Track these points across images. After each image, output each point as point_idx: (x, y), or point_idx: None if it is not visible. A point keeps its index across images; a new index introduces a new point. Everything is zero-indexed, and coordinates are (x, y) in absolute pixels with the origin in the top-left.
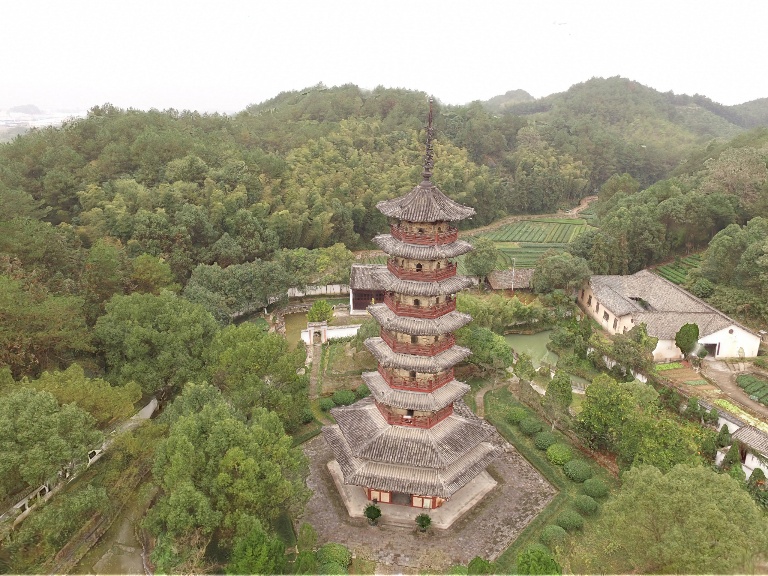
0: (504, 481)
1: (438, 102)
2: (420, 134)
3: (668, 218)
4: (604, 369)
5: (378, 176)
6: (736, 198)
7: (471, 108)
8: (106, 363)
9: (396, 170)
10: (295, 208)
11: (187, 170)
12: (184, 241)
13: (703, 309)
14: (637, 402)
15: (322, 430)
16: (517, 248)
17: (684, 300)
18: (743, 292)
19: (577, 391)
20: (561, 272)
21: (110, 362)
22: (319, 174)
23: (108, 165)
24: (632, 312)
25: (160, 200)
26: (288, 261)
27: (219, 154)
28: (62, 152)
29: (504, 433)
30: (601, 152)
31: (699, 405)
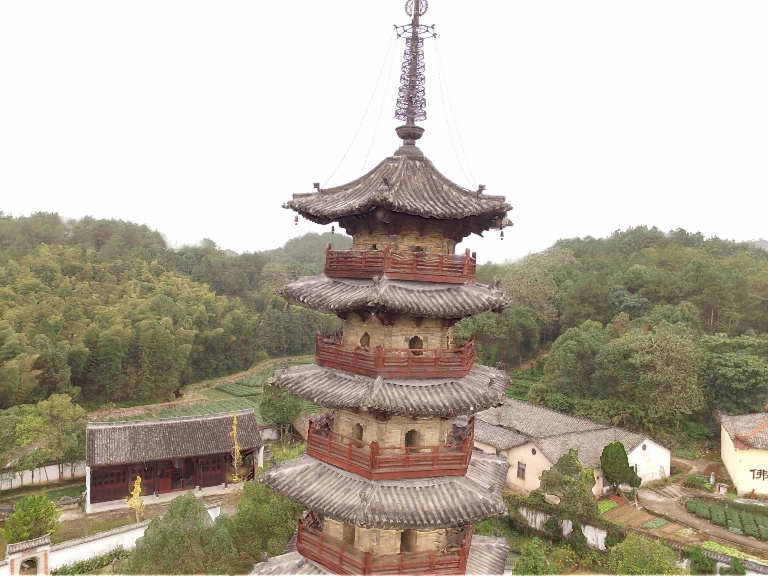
0: None
1: (163, 238)
2: (151, 265)
3: (480, 334)
4: (527, 529)
5: (103, 309)
6: (533, 311)
7: (203, 246)
8: None
9: None
10: None
11: None
12: None
13: (593, 425)
14: (608, 572)
15: None
16: None
17: (560, 419)
18: (611, 402)
19: None
20: None
21: None
22: (9, 305)
23: None
24: (533, 439)
25: None
26: None
27: None
28: None
29: None
30: None
31: (706, 557)
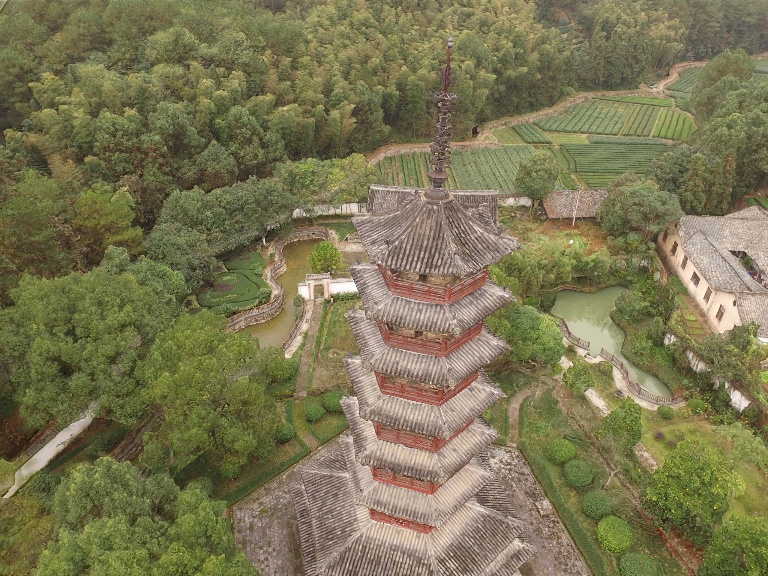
0: (533, 574)
1: None
2: None
3: None
4: (686, 369)
5: (418, 46)
6: None
7: None
8: (9, 379)
9: (441, 37)
10: (307, 99)
11: (171, 48)
12: (159, 154)
13: None
14: None
15: (290, 489)
16: (585, 144)
17: None
18: None
19: (646, 404)
20: (641, 212)
21: (13, 379)
22: (344, 44)
23: (75, 40)
24: (737, 293)
25: (132, 94)
26: (292, 178)
27: (214, 23)
28: (17, 23)
29: (541, 479)
30: (704, 4)
31: None
